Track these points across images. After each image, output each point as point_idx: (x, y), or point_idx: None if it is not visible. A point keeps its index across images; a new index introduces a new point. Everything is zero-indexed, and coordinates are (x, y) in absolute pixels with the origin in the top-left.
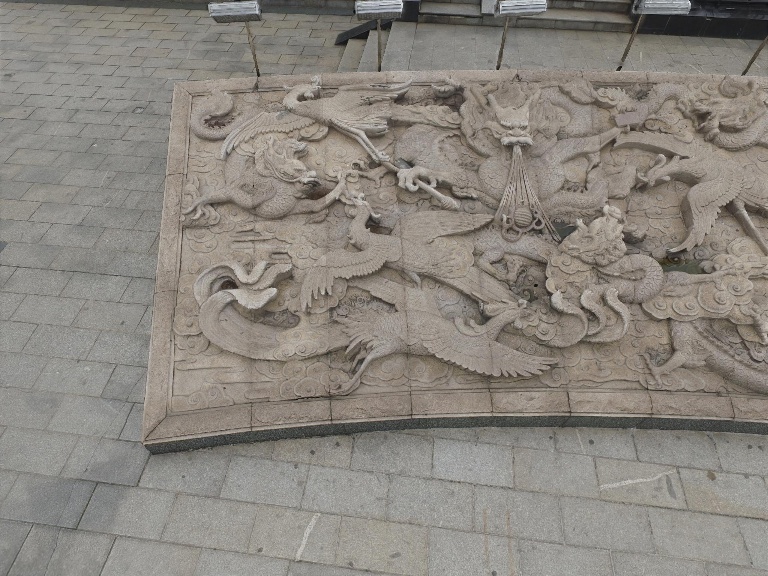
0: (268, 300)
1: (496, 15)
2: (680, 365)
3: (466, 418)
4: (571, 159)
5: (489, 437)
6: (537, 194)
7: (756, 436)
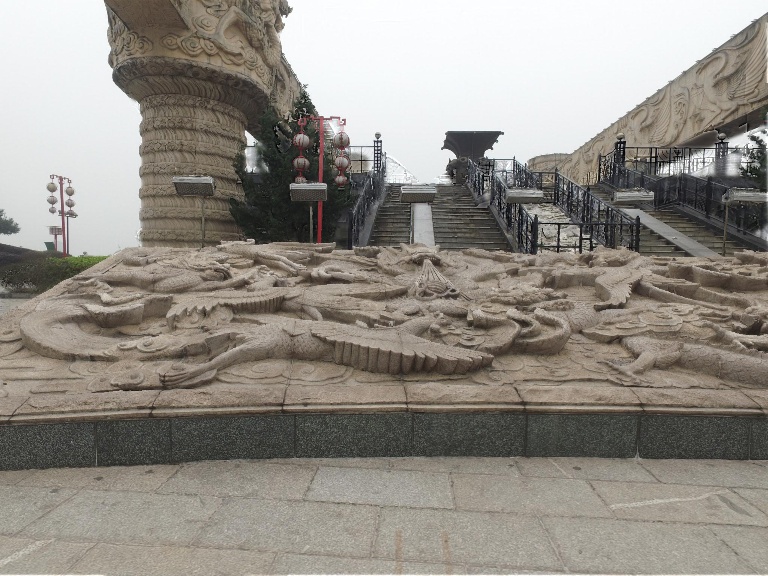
0: (127, 312)
1: (400, 199)
2: (651, 360)
3: (369, 417)
4: (482, 281)
5: (411, 465)
6: None
7: None
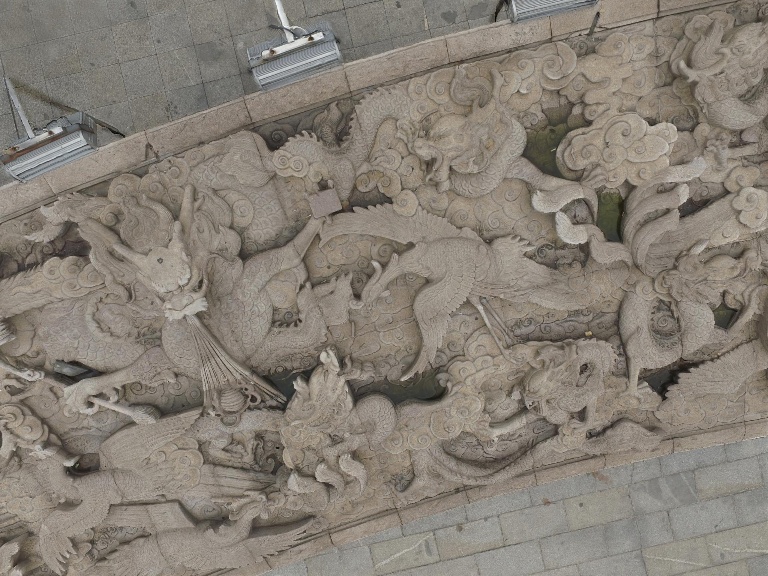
0: None
1: None
2: None
3: None
4: None
5: None
6: (242, 355)
7: None
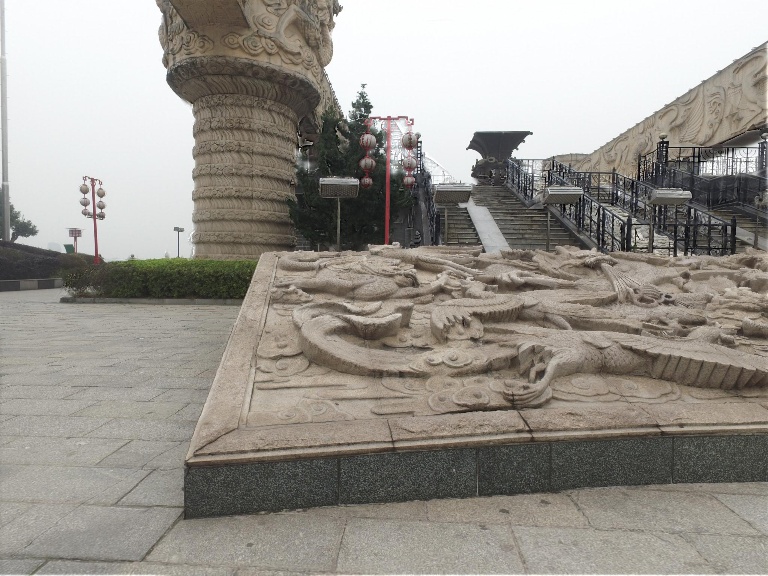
0: (391, 322)
1: (544, 200)
2: None
3: (747, 439)
4: (656, 285)
5: None
6: None
7: None
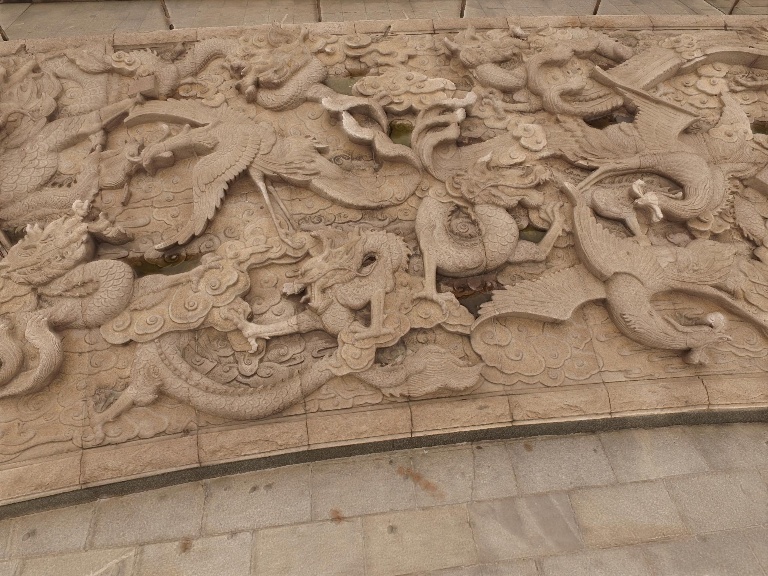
0: None
1: None
2: (125, 406)
3: None
4: (73, 145)
5: None
6: None
7: (267, 472)
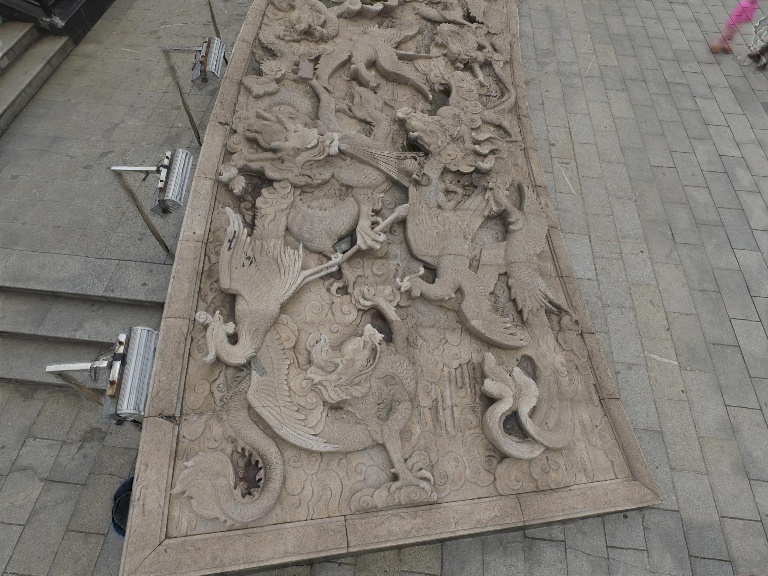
0: None
1: None
2: None
3: None
4: None
5: None
6: None
7: None
